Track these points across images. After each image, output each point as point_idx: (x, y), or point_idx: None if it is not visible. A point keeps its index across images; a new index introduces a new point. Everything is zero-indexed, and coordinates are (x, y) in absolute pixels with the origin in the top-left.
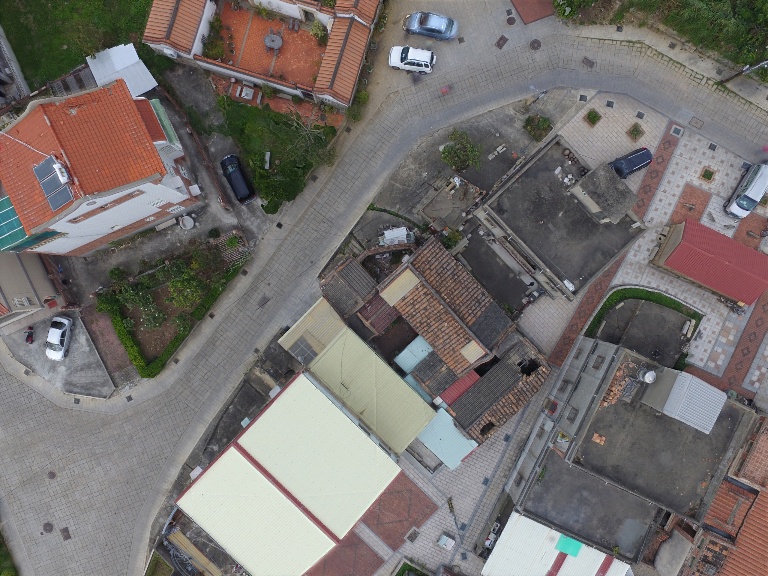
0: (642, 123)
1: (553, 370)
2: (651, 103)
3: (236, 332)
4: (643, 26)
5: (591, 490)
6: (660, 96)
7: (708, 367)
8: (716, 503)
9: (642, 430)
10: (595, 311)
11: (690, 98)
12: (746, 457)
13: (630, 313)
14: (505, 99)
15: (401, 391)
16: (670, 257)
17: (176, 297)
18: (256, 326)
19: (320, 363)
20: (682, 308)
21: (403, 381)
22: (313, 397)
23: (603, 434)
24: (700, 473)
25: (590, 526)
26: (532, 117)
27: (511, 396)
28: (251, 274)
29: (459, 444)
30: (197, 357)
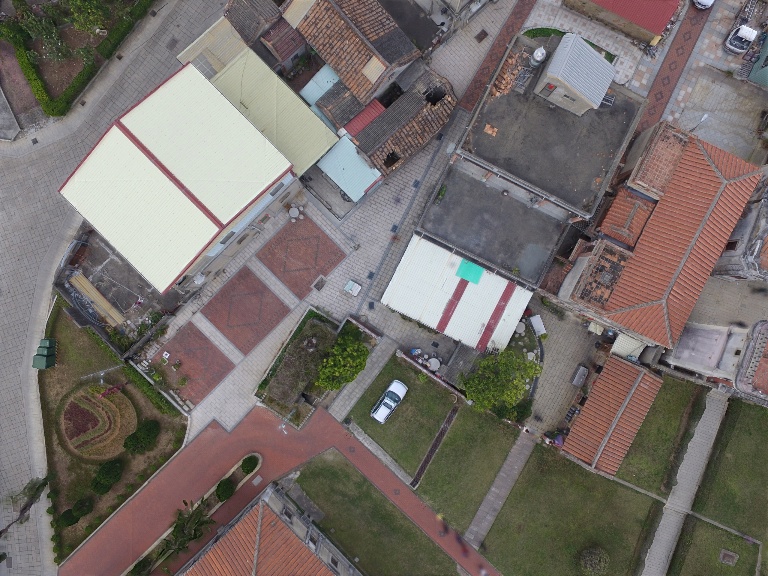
0: None
1: (464, 115)
2: None
3: (144, 74)
4: None
5: (493, 213)
6: None
7: None
8: (614, 211)
9: (535, 122)
10: None
11: None
12: (644, 160)
13: None
14: None
15: (302, 114)
16: None
17: (76, 17)
18: (164, 69)
19: (219, 81)
20: None
21: (305, 105)
22: (201, 86)
23: (495, 125)
24: (594, 169)
25: (491, 250)
26: None
27: (415, 124)
28: (160, 15)
29: (362, 174)
30: (104, 100)
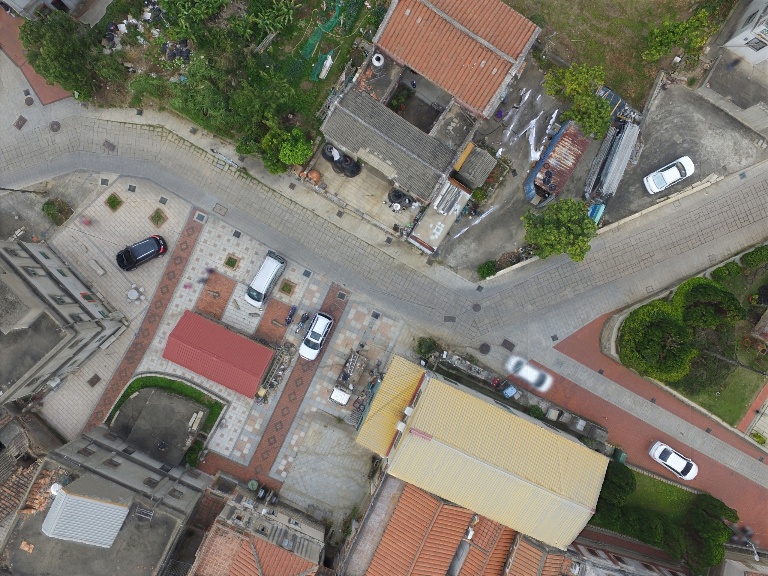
0: (165, 208)
1: None
2: (174, 188)
3: None
4: (163, 110)
5: None
6: (183, 182)
7: (234, 456)
8: None
9: None
10: (116, 399)
11: (213, 184)
12: None
13: (144, 403)
14: (25, 181)
15: None
16: (164, 350)
17: None
18: None
19: None
20: (203, 397)
21: None
22: None
23: (32, 542)
24: None
25: None
26: (52, 200)
27: (6, 489)
28: None
29: None
30: None
